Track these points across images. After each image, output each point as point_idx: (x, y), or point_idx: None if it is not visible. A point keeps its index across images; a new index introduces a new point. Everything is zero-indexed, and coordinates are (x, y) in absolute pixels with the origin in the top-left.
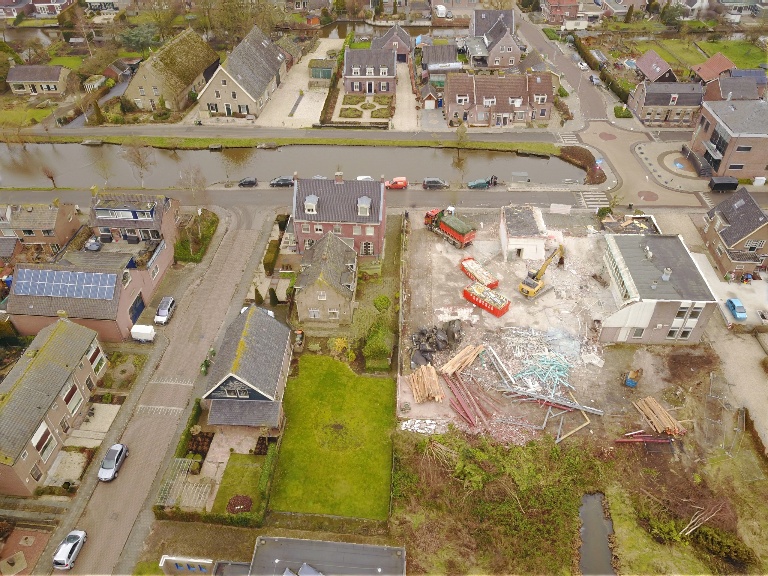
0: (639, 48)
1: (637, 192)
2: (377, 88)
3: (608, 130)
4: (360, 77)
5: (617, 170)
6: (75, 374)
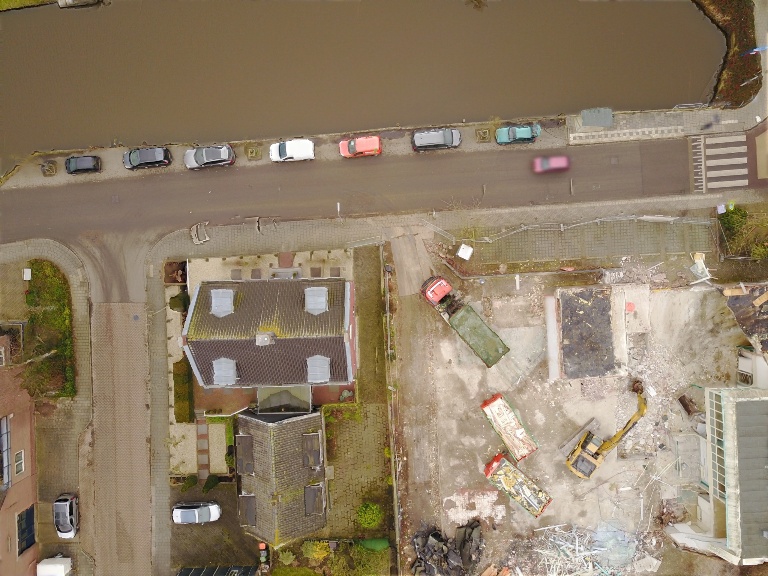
0: None
1: None
2: None
3: None
4: None
5: None
6: None
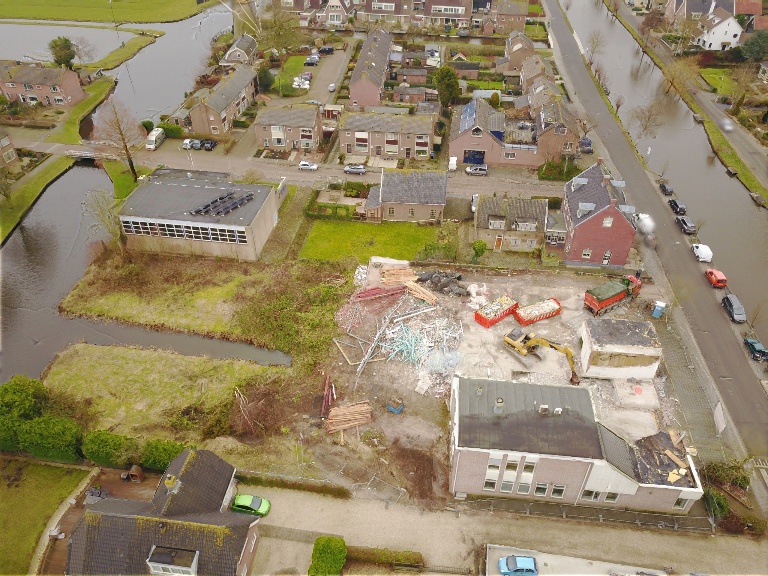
0: None
1: None
2: None
3: None
4: None
5: None
6: (401, 136)
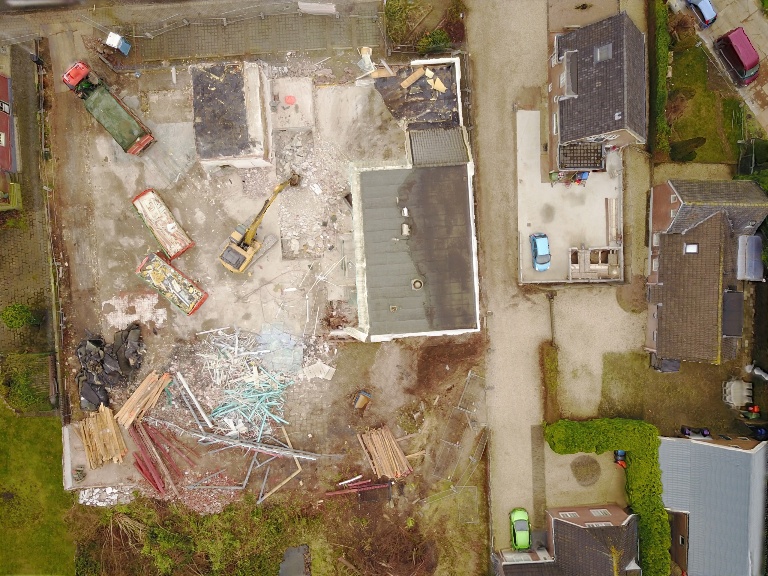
0: None
1: None
2: None
3: None
4: None
5: None
6: None
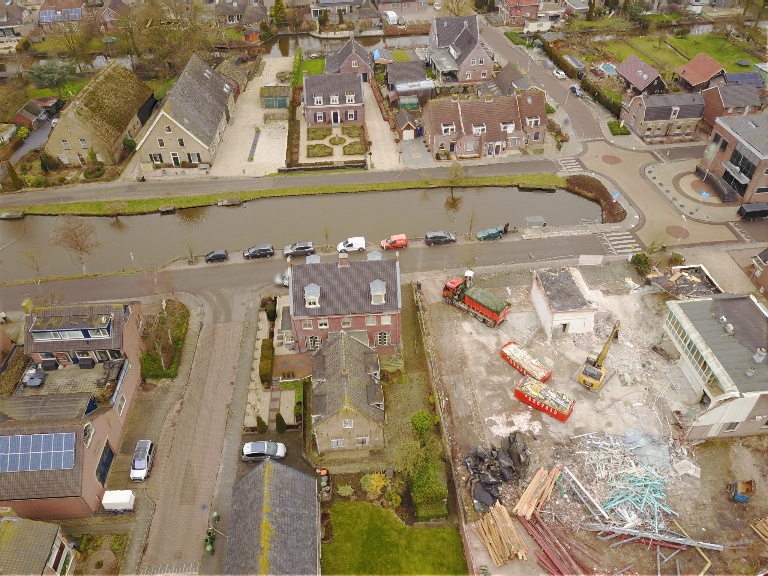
0: (609, 49)
1: (664, 228)
2: (343, 117)
3: (609, 151)
4: (323, 107)
5: (634, 202)
6: None
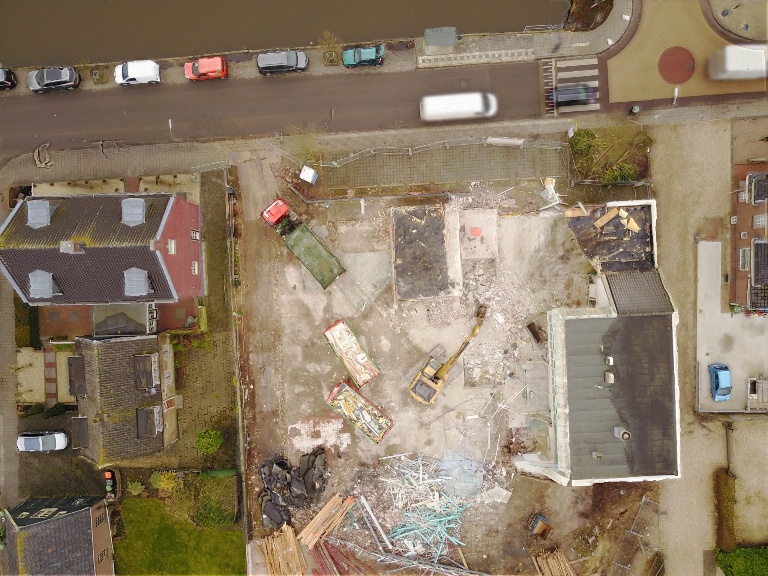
0: None
1: (659, 54)
2: None
3: None
4: None
5: None
6: None
